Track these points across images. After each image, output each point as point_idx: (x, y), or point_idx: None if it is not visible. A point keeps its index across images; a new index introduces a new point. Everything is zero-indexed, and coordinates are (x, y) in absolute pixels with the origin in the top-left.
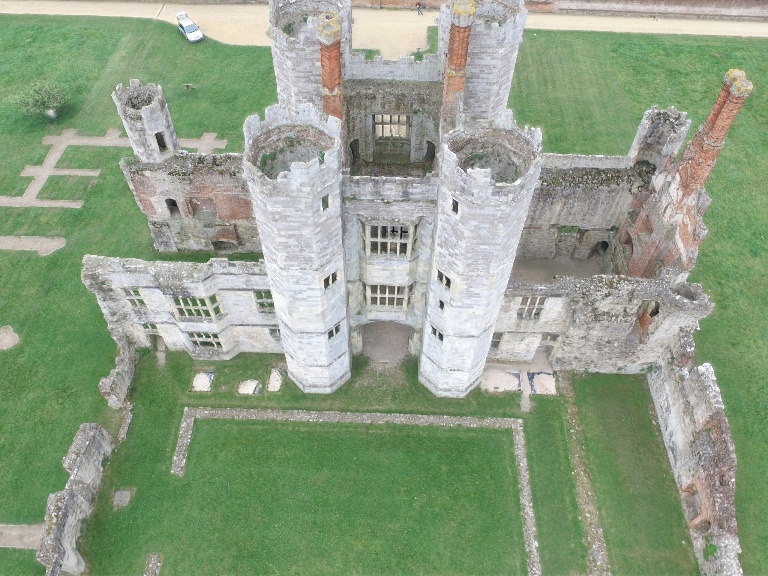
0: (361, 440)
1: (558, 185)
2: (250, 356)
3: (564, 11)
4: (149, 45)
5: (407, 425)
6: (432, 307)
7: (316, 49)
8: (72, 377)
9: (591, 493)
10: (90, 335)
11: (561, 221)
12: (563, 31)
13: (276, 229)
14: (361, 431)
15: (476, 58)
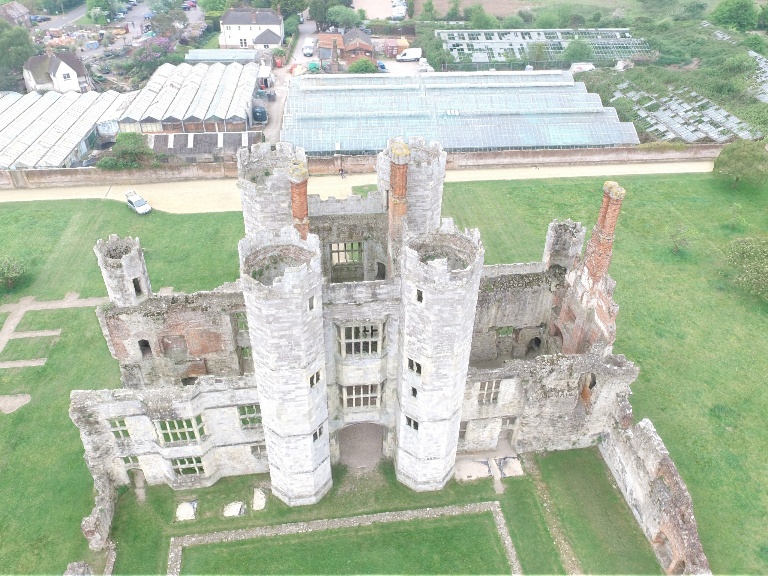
0: (352, 543)
1: (491, 291)
2: (231, 480)
3: (463, 167)
4: (100, 220)
5: (394, 522)
6: (406, 397)
7: (281, 193)
8: (47, 526)
9: (575, 559)
10: (63, 482)
11: (498, 323)
12: (466, 182)
13: (270, 331)
14: (351, 535)
15: (412, 191)
